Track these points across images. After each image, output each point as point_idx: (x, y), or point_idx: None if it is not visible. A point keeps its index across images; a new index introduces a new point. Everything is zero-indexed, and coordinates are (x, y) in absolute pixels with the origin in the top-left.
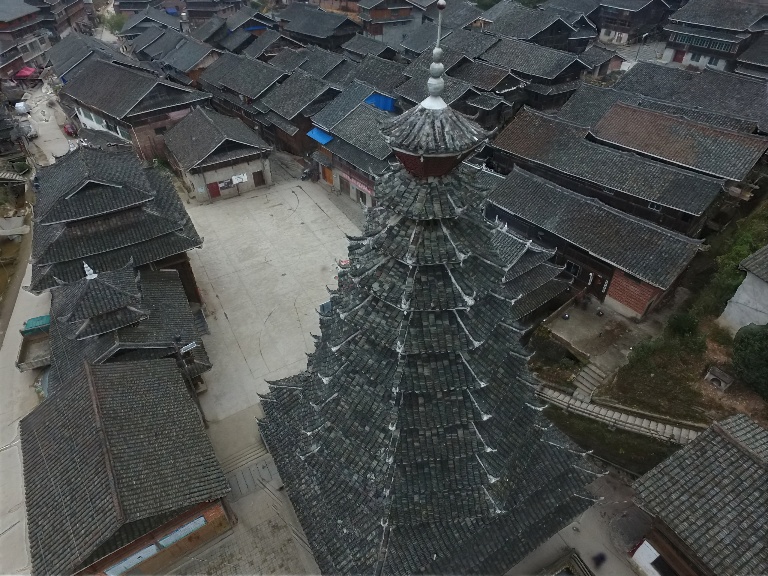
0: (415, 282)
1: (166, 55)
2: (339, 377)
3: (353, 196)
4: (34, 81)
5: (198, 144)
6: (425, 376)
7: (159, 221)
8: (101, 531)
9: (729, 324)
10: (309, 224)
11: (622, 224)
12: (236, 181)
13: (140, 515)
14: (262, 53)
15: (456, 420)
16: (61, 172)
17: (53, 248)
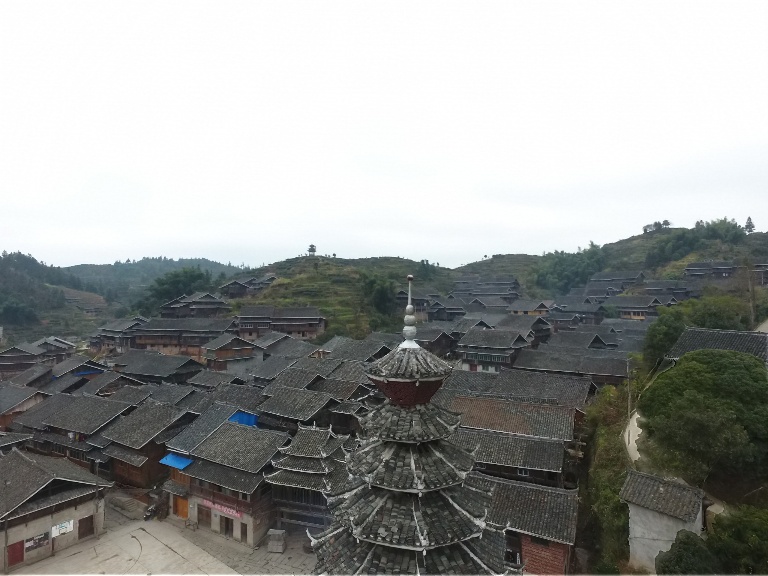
0: (423, 516)
1: None
2: None
3: (215, 526)
4: None
5: (8, 492)
6: None
7: None
8: None
9: (641, 563)
10: (159, 574)
11: (508, 490)
12: (56, 533)
13: None
14: (96, 393)
15: None
16: None
17: None
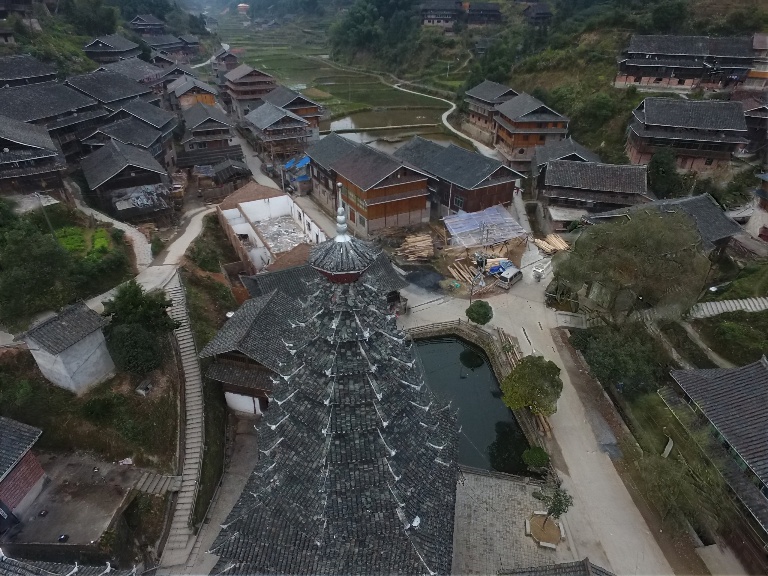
0: None
1: None
2: None
3: None
4: None
5: None
6: None
7: None
8: (604, 575)
9: (86, 386)
10: None
11: None
12: None
13: (572, 563)
14: None
15: None
16: None
17: None
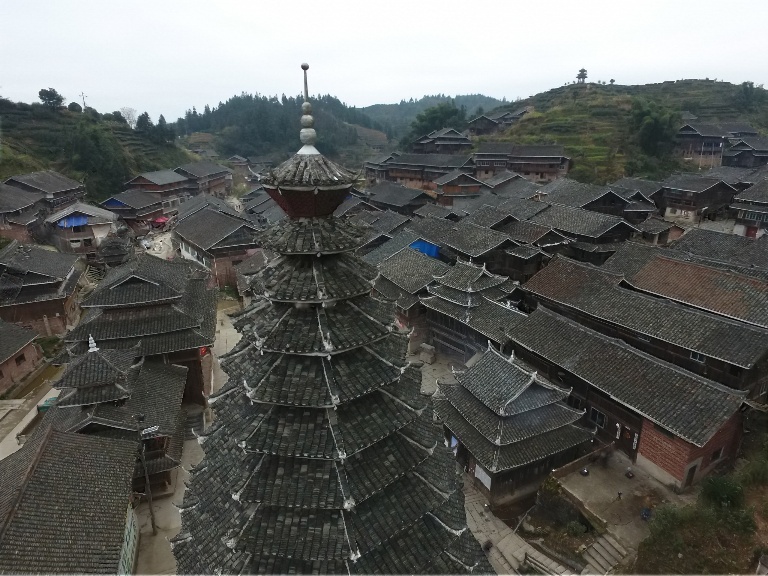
0: (280, 323)
1: (265, 211)
2: (214, 438)
3: None
4: (159, 223)
5: None
6: (282, 437)
7: (181, 318)
8: None
9: None
10: None
11: (650, 368)
12: None
13: None
14: (344, 214)
15: (313, 502)
16: (120, 271)
17: (84, 328)
